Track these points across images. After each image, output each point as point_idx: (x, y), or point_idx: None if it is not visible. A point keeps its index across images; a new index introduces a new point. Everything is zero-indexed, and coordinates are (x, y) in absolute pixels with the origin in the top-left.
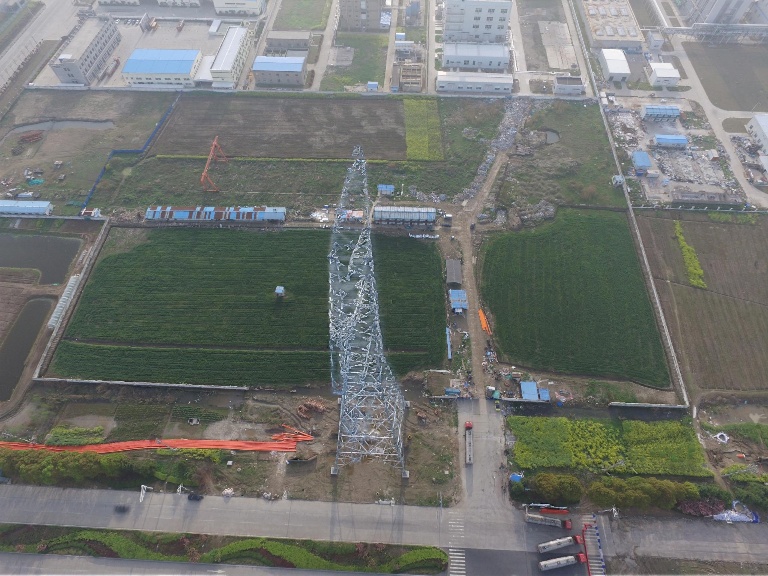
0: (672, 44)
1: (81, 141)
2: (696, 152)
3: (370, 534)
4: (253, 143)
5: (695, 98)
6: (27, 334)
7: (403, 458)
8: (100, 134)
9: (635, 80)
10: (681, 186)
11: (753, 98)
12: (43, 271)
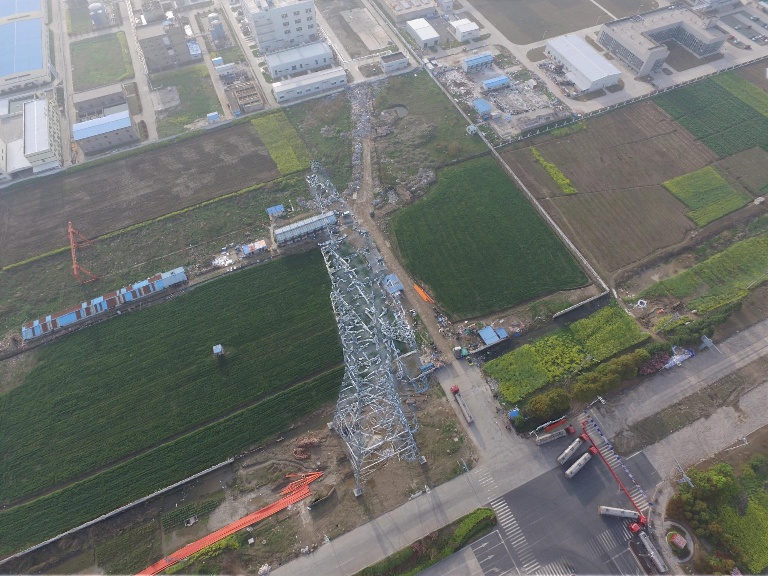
0: (459, 2)
1: None
2: (519, 86)
3: (418, 530)
4: (112, 215)
5: (497, 42)
6: None
7: None
8: None
9: (445, 41)
10: (521, 117)
11: (539, 29)
12: None
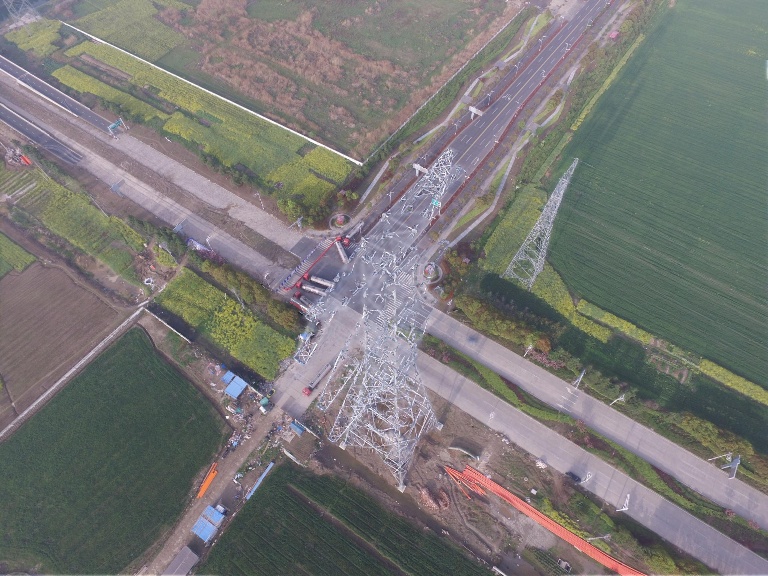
0: None
1: None
2: None
3: (434, 366)
4: None
5: None
6: None
7: None
8: None
9: None
10: None
11: None
12: None
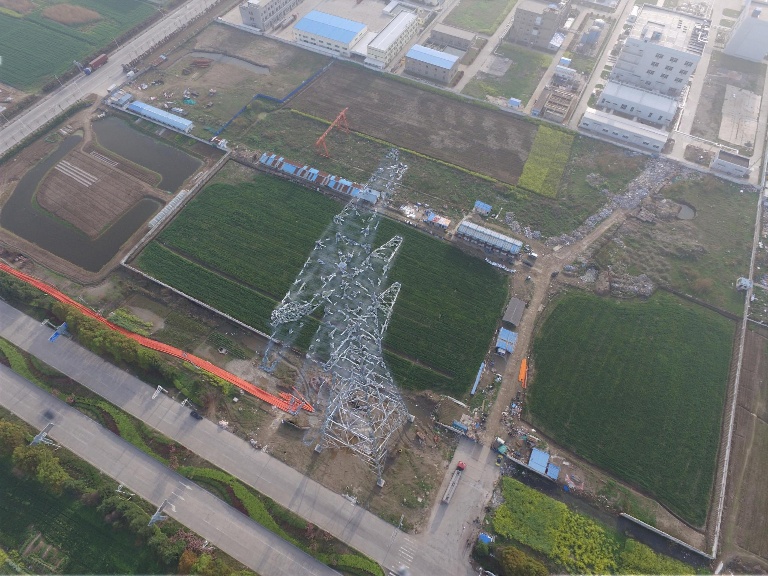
0: None
1: (237, 78)
2: None
3: (325, 520)
4: (378, 124)
5: None
6: (132, 225)
7: (383, 466)
8: (255, 76)
9: None
10: None
11: None
12: (164, 178)
